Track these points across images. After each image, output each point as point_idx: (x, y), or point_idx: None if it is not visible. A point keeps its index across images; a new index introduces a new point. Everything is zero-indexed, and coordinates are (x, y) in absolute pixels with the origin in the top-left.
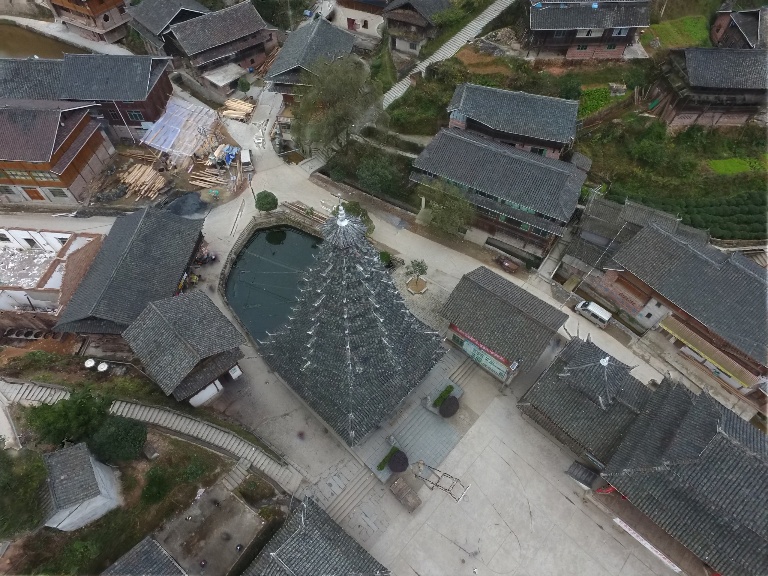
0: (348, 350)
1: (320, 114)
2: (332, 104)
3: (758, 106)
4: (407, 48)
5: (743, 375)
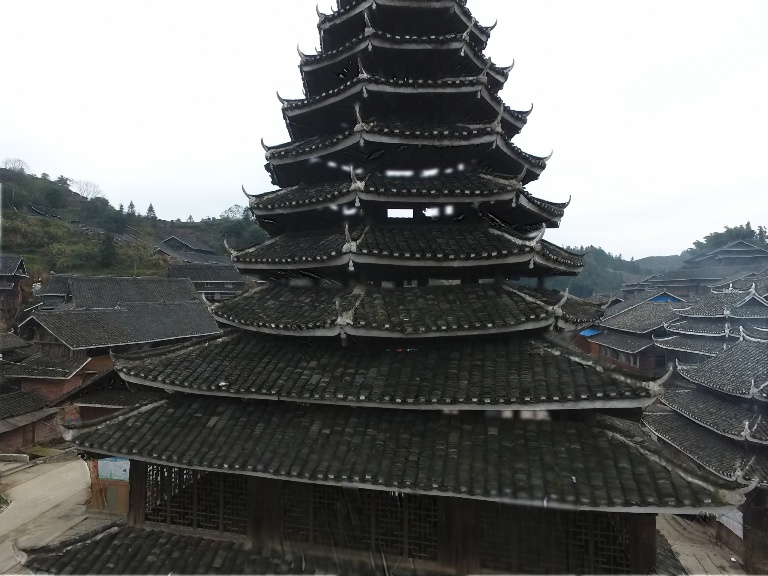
0: None
1: None
2: None
3: None
4: None
5: None
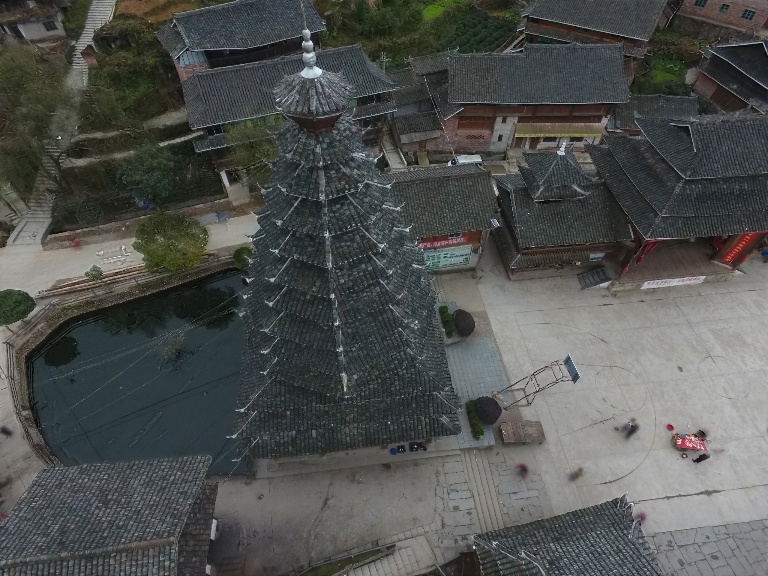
0: (395, 306)
1: (4, 125)
2: (11, 106)
3: None
4: (43, 32)
5: (593, 128)
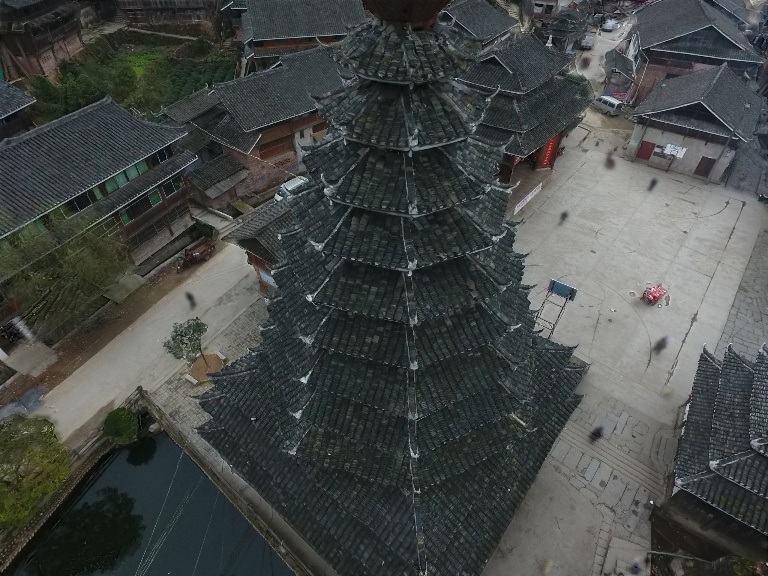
0: None
1: None
2: None
3: (74, 19)
4: None
5: None
